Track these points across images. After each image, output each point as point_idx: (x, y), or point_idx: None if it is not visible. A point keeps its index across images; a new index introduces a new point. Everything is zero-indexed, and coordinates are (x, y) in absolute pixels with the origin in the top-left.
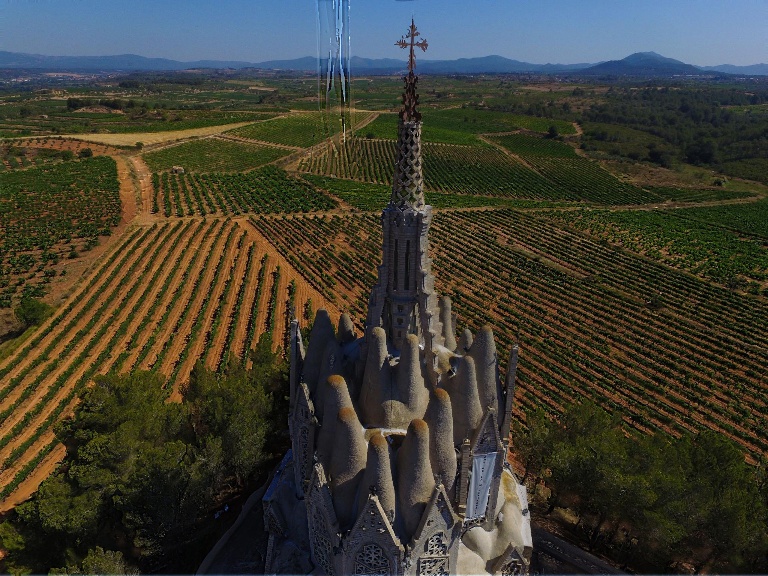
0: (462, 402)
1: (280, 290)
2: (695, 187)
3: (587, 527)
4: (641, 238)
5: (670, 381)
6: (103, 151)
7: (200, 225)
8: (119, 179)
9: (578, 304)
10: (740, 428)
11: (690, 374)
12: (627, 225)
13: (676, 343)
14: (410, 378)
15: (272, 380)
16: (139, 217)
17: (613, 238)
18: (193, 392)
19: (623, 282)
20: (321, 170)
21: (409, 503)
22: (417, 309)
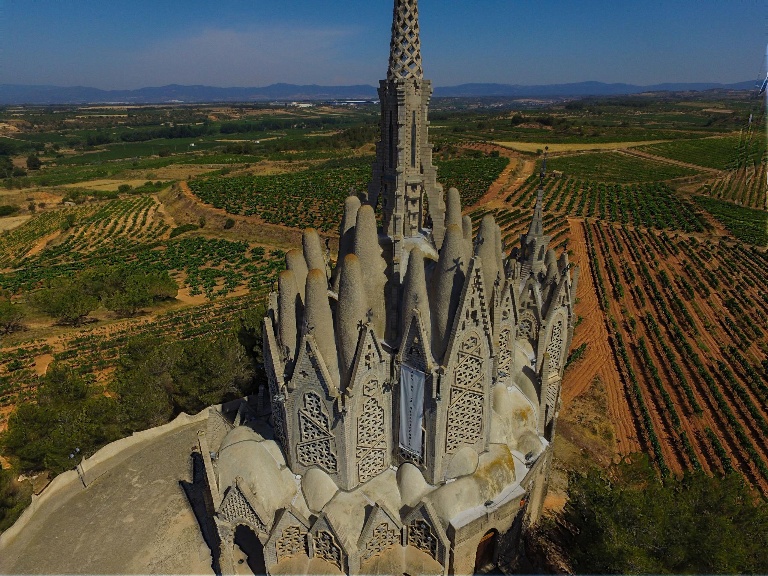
0: (404, 298)
1: None
2: None
3: None
4: None
5: None
6: (507, 154)
7: None
8: (501, 174)
9: None
10: None
11: None
12: None
13: None
14: (355, 247)
15: None
16: (491, 202)
17: None
18: None
19: None
20: (722, 193)
21: None
22: None
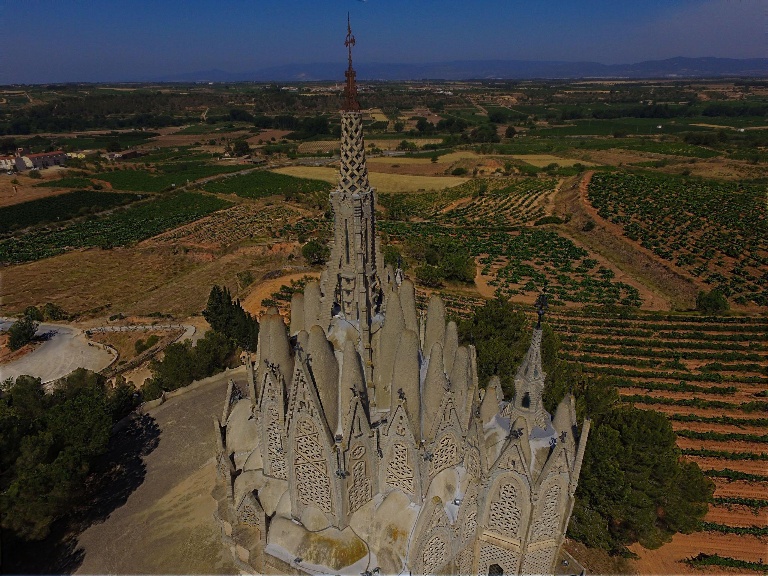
0: None
1: None
2: None
3: None
4: None
5: None
6: None
7: None
8: None
9: None
10: None
11: None
12: None
13: None
14: None
15: None
16: None
17: None
18: None
19: None
20: None
21: None
22: None
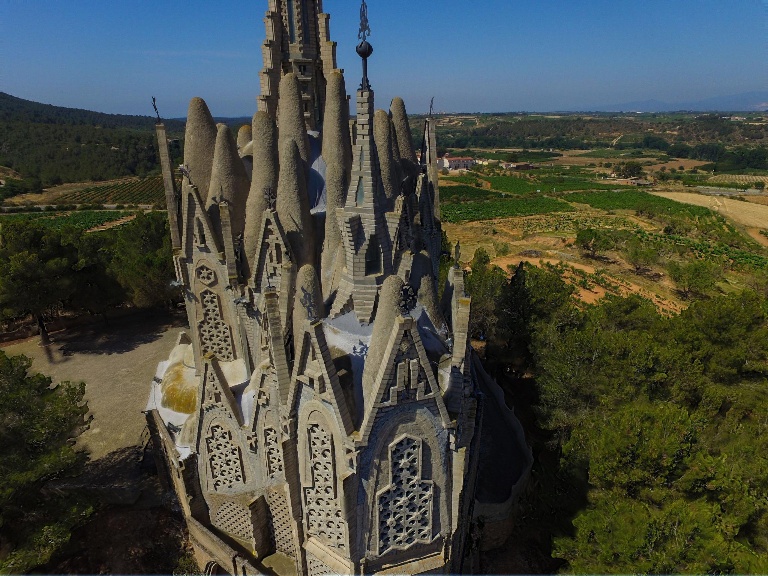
0: None
1: None
2: None
3: None
4: None
5: None
6: None
7: None
8: None
9: None
10: None
11: None
12: None
13: None
14: None
15: None
16: None
17: None
18: None
19: None
20: None
21: None
22: None
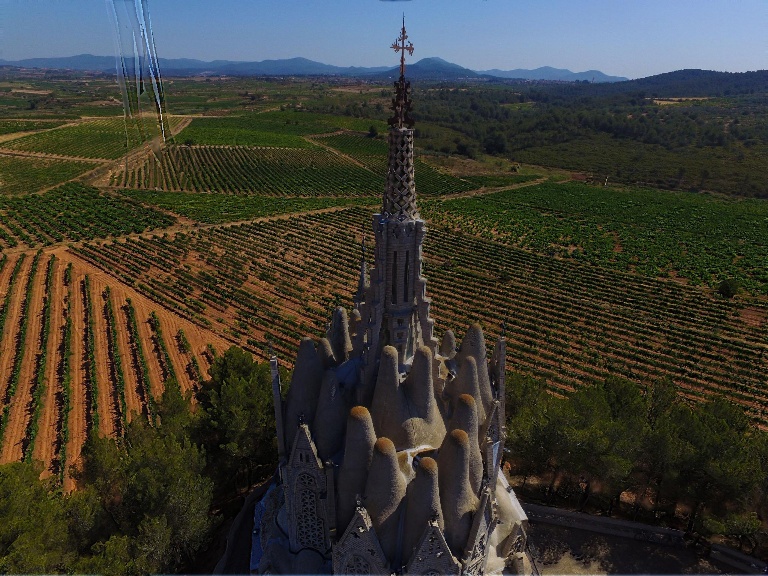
0: None
1: (139, 326)
2: (498, 174)
3: (544, 485)
4: (474, 222)
5: (537, 341)
6: None
7: (0, 264)
8: None
9: (446, 288)
10: (596, 368)
11: (549, 332)
12: (459, 212)
13: (530, 308)
14: (428, 391)
15: (192, 431)
16: None
17: (452, 225)
18: (88, 472)
19: (474, 263)
20: (142, 183)
21: (457, 517)
22: (413, 320)
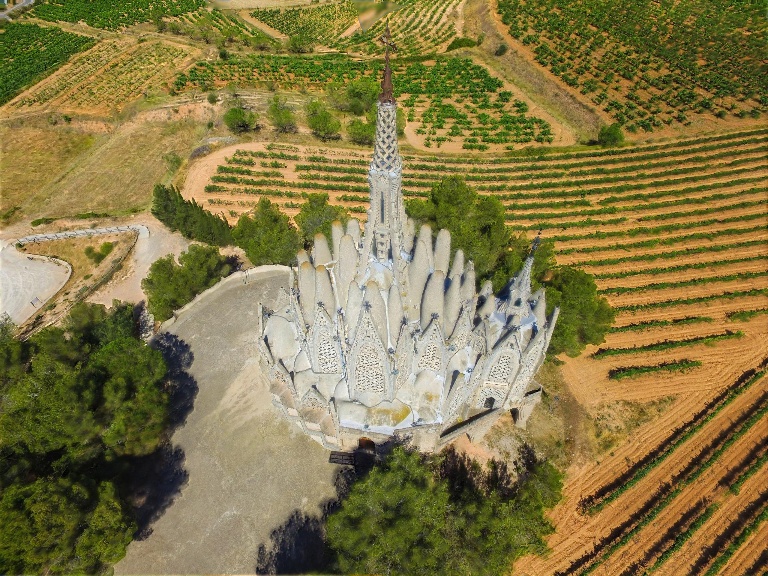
0: None
1: None
2: None
3: None
4: None
5: None
6: None
7: None
8: None
9: None
10: None
11: None
12: None
13: None
14: None
15: None
16: None
17: None
18: None
19: None
20: None
21: None
22: None
